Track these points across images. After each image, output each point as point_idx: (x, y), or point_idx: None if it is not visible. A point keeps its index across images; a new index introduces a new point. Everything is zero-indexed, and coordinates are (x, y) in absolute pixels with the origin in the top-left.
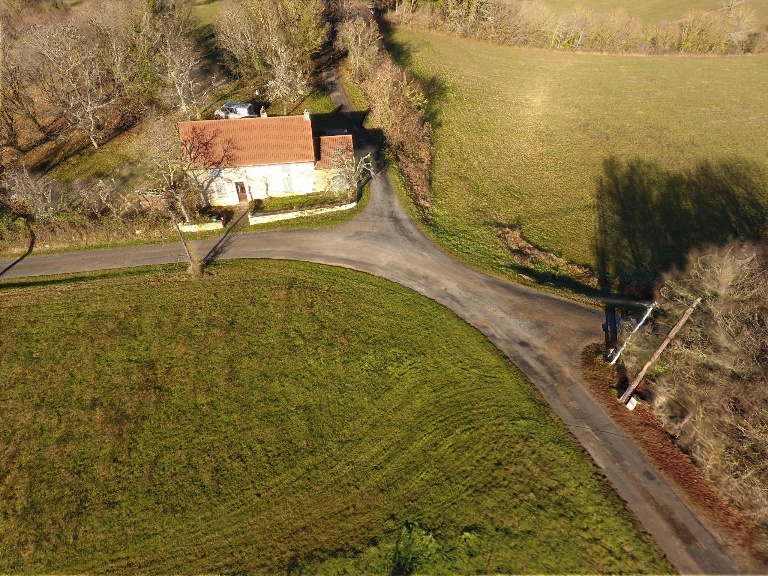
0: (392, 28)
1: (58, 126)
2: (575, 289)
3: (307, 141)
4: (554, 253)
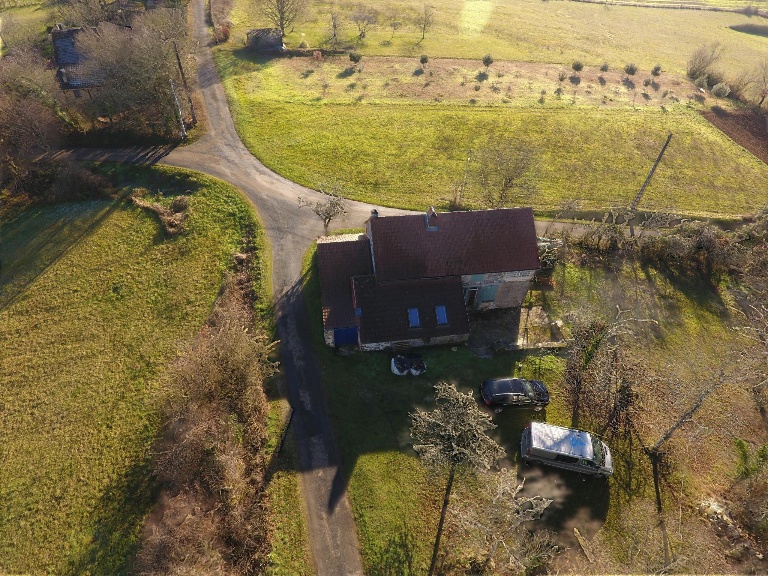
0: None
1: None
2: (159, 182)
3: None
4: (144, 214)
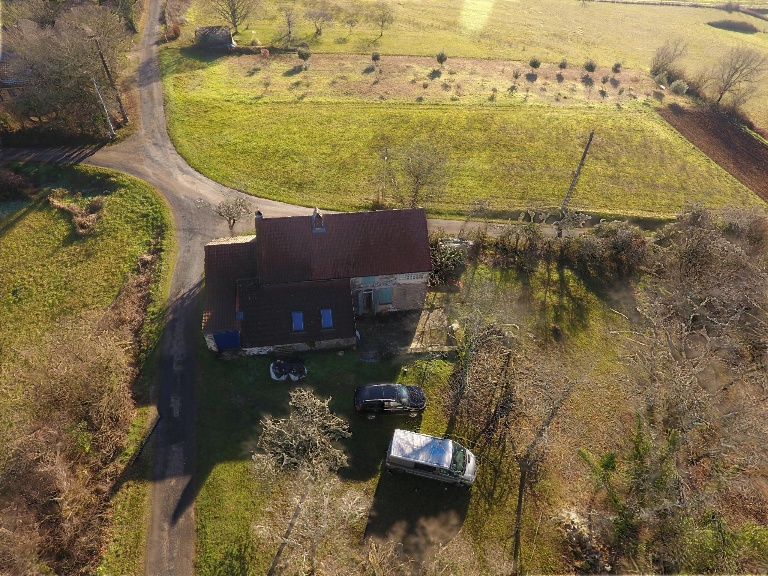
0: None
1: None
2: (80, 182)
3: None
4: (59, 215)
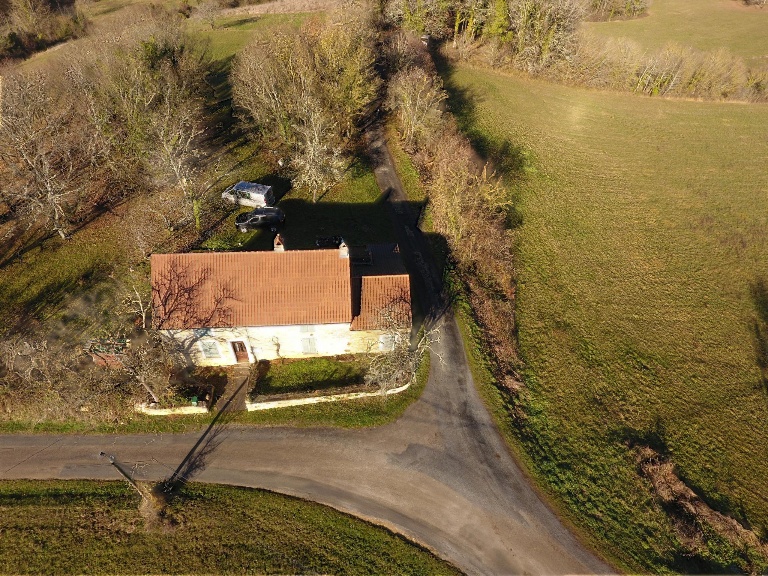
0: (450, 65)
1: None
2: None
3: (342, 290)
4: (733, 511)
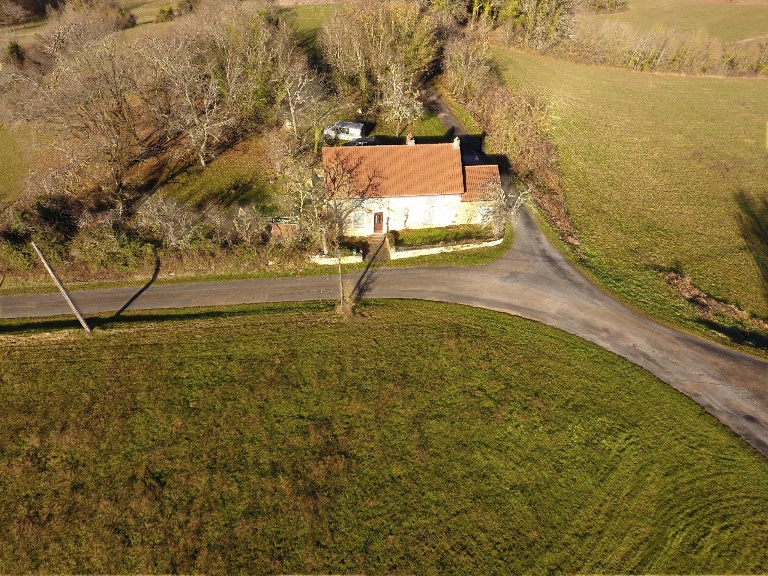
0: None
1: (156, 140)
2: None
3: (456, 171)
4: (731, 304)
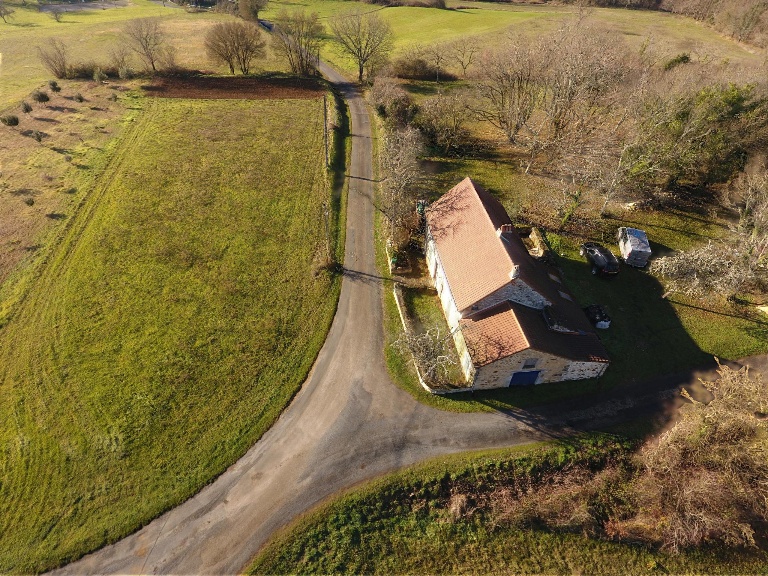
0: None
1: None
2: None
3: (482, 291)
4: None
